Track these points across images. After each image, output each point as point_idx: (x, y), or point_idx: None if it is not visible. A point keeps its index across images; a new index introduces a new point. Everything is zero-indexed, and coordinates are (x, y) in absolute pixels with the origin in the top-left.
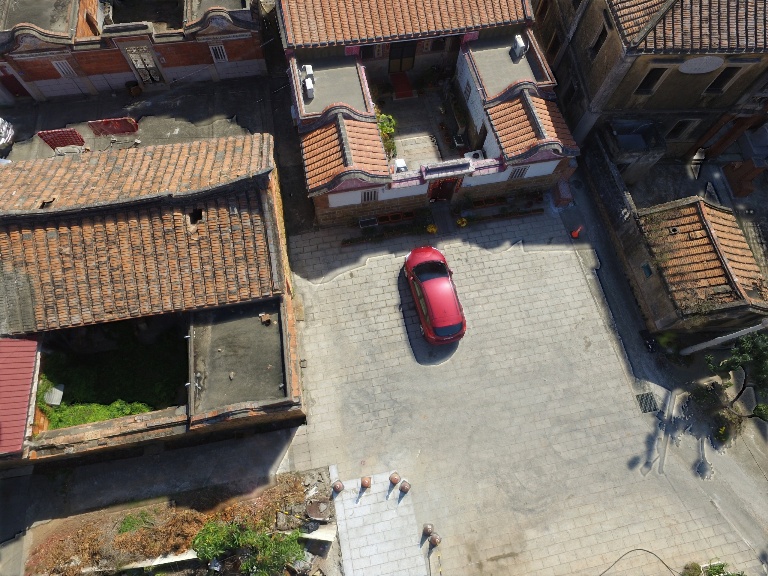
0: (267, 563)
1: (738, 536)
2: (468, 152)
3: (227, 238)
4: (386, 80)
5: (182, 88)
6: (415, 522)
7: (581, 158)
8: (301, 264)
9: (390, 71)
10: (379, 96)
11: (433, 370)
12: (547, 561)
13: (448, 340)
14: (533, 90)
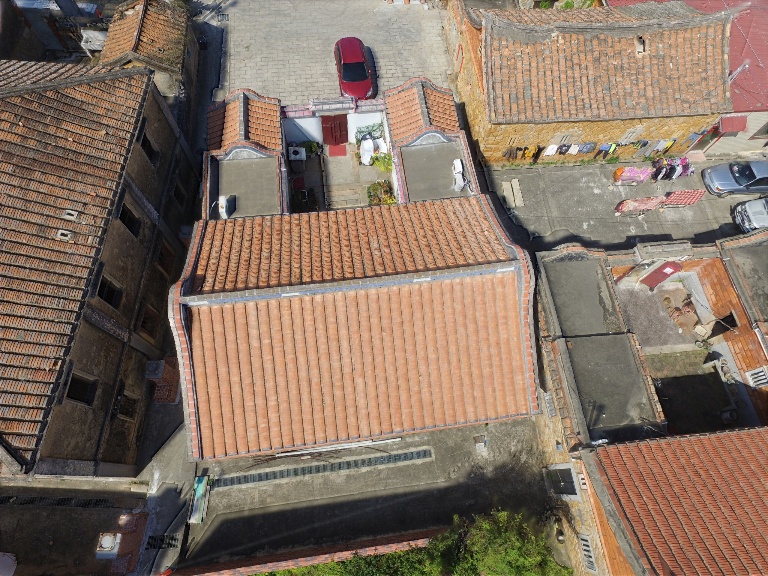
0: None
1: None
2: None
3: None
4: None
5: None
6: None
7: None
8: None
9: None
10: None
11: None
12: None
13: None
14: None
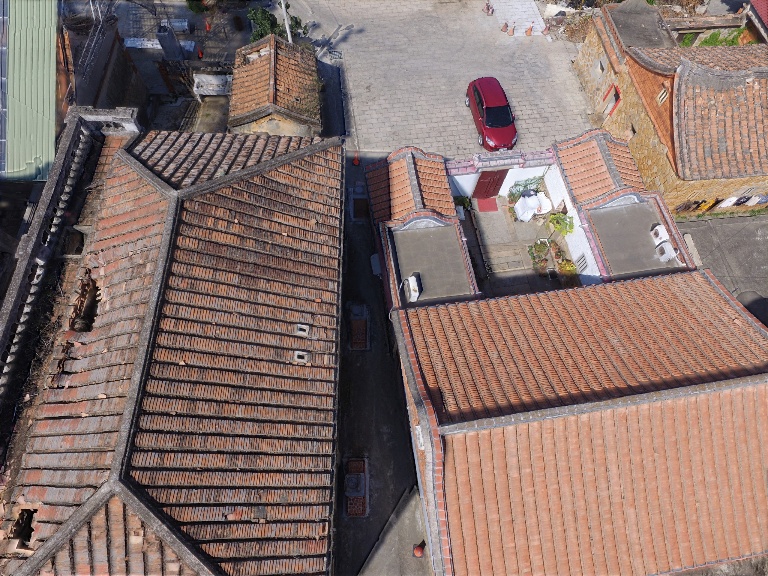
0: None
1: (305, 0)
2: None
3: None
4: None
5: None
6: (498, 17)
7: None
8: None
9: None
10: None
11: None
12: None
13: None
14: None
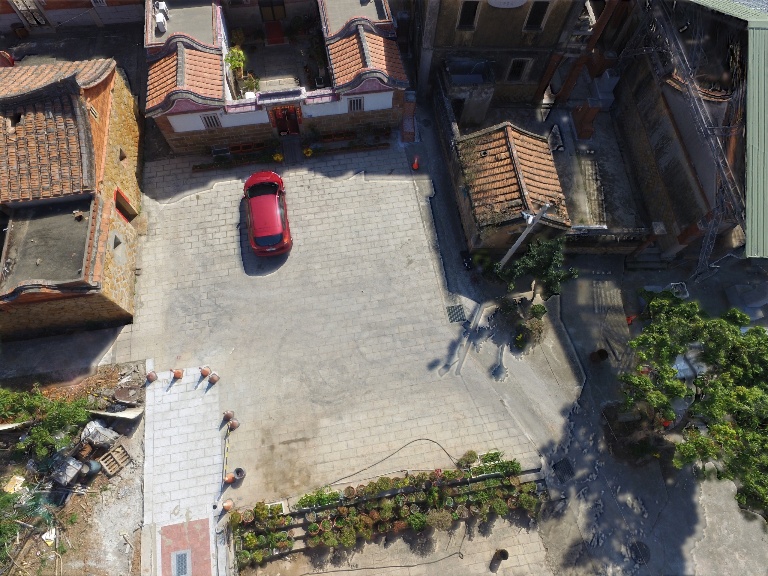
0: (51, 424)
1: (520, 431)
2: (320, 89)
3: (42, 139)
4: (260, 28)
5: (68, 32)
6: (218, 409)
7: (432, 99)
8: (152, 186)
9: (264, 19)
10: (252, 42)
11: (259, 280)
12: (335, 446)
13: (272, 252)
14: (368, 27)
